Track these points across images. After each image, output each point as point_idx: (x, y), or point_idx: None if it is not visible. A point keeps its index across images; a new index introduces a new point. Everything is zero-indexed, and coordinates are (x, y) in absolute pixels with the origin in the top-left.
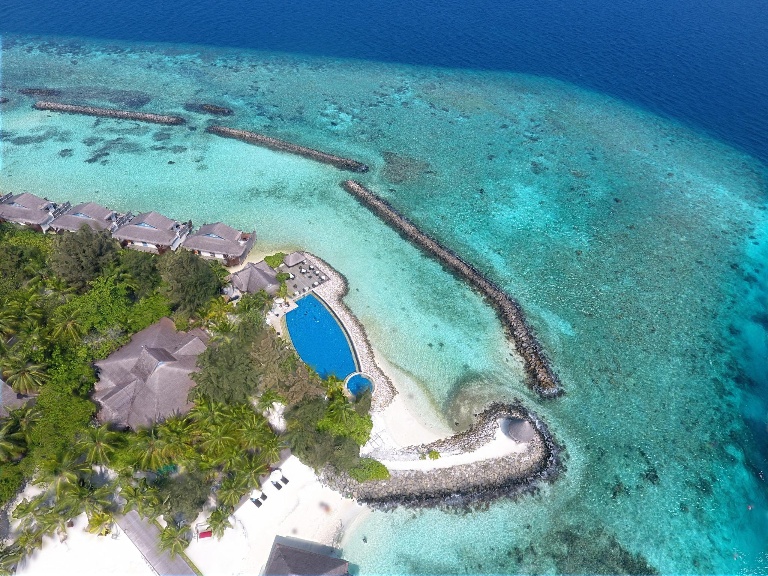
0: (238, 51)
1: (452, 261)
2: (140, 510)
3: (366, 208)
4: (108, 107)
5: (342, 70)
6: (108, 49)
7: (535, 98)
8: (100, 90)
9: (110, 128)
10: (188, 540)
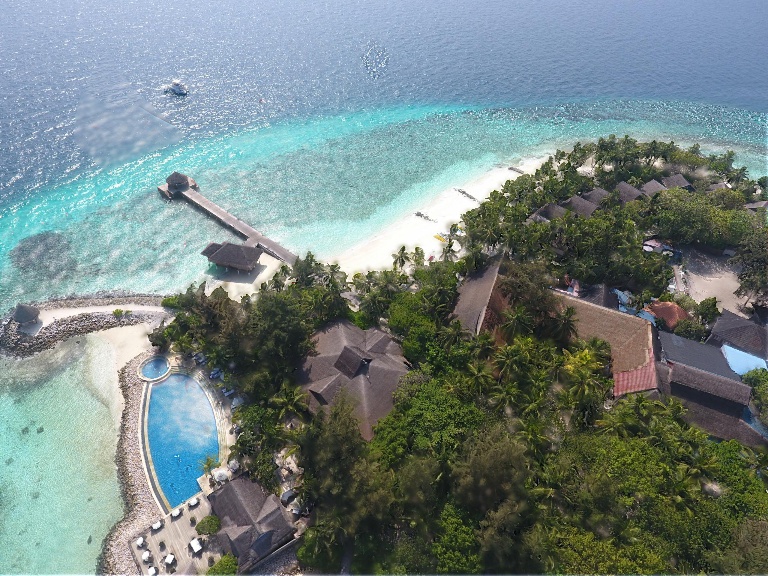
0: None
1: None
2: None
3: None
4: None
5: None
6: None
7: None
8: None
9: None
10: None
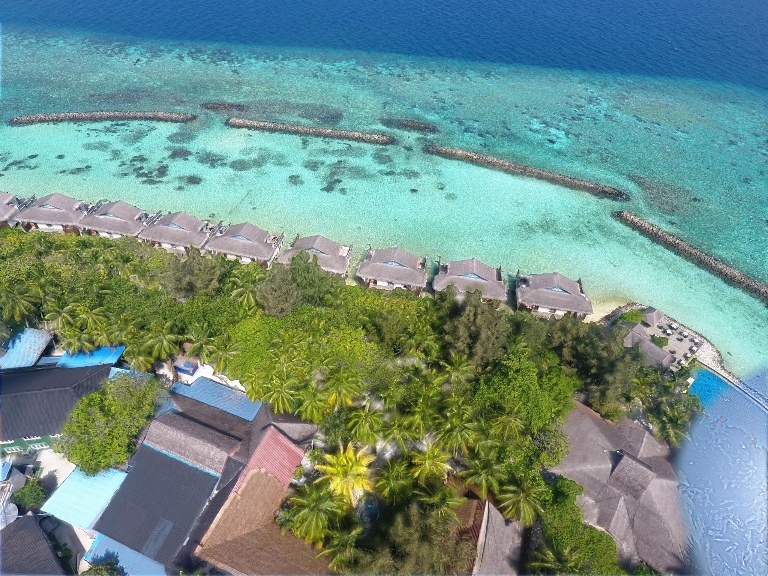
0: (393, 57)
1: None
2: None
3: (661, 246)
4: (304, 124)
5: (515, 77)
6: (260, 56)
7: (739, 108)
8: (283, 104)
9: (322, 149)
10: None
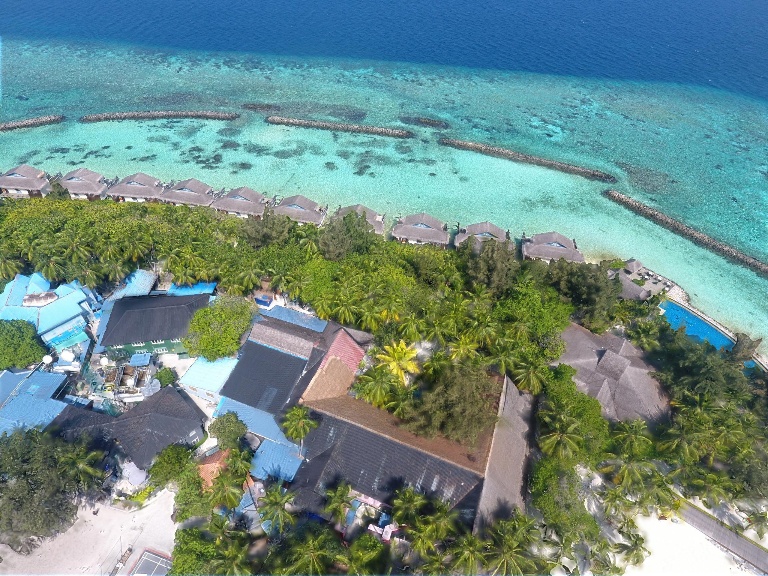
0: (406, 65)
1: (766, 267)
2: (725, 495)
3: (643, 217)
4: (333, 121)
5: (516, 82)
6: (288, 64)
7: (715, 108)
8: (313, 105)
9: (351, 141)
10: (740, 524)
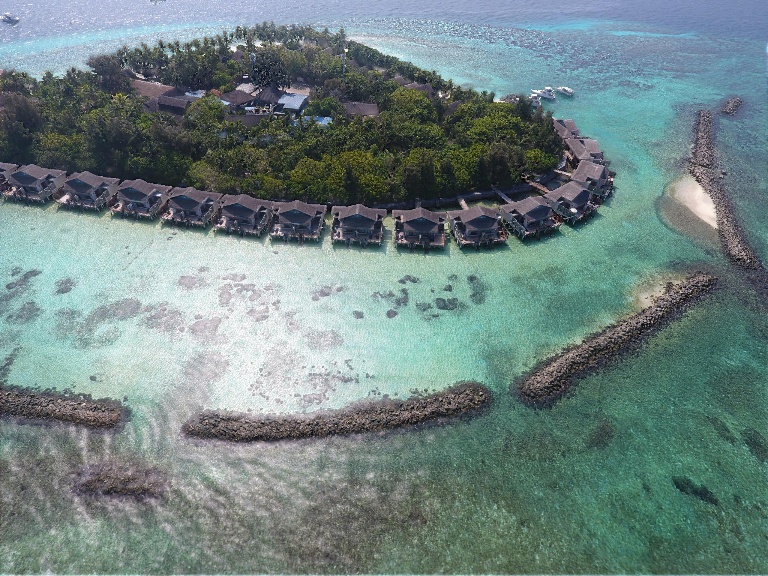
0: None
1: None
2: None
3: None
4: None
5: None
6: None
7: None
8: None
9: None
10: None
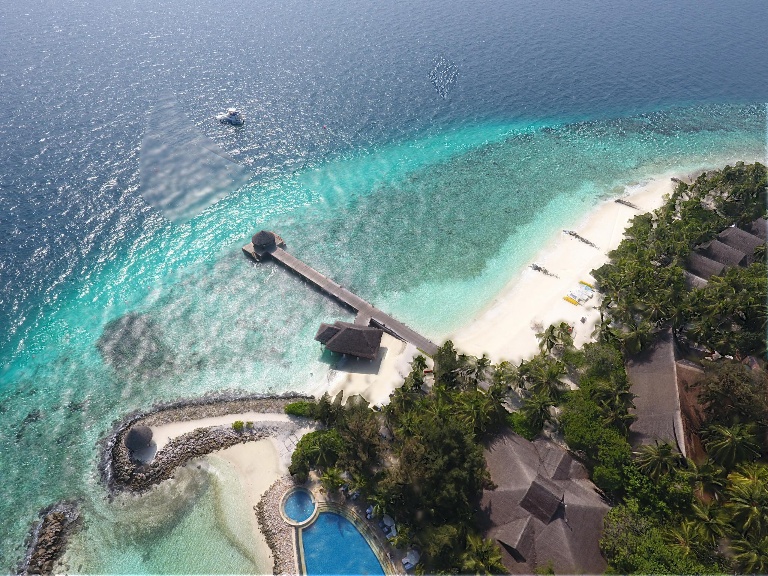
0: None
1: None
2: None
3: None
4: None
5: None
6: None
7: None
8: None
9: None
10: None
